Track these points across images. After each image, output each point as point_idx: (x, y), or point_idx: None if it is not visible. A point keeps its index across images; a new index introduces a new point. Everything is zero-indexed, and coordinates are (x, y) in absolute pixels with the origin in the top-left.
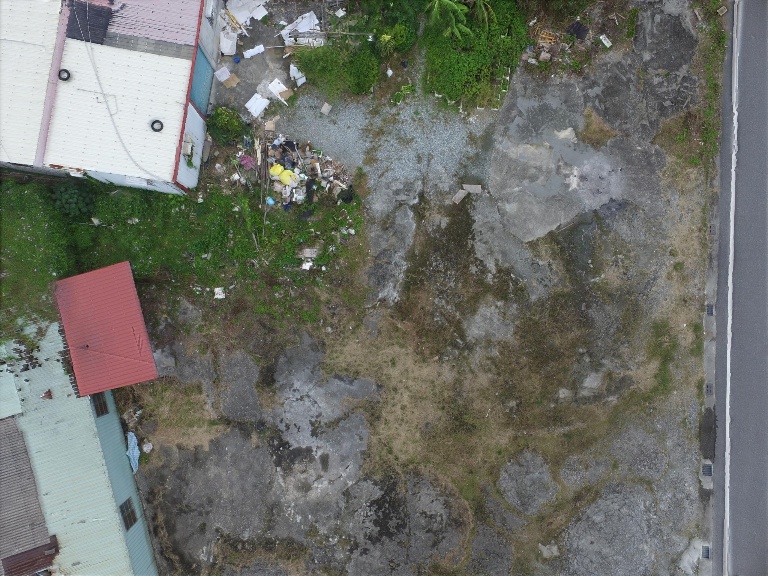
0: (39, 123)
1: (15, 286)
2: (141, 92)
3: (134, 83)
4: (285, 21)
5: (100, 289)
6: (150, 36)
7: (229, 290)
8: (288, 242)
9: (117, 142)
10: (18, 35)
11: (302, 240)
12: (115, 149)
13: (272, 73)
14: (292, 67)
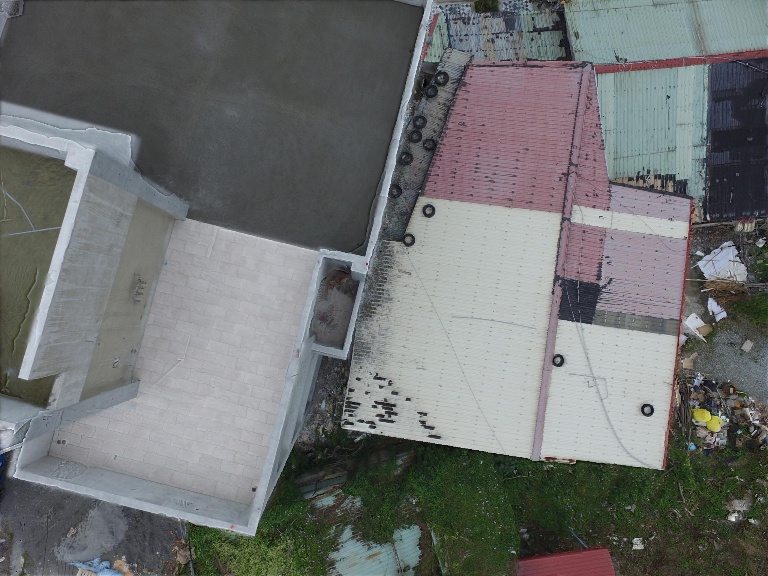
0: (534, 413)
1: (478, 568)
2: (630, 373)
3: (623, 364)
4: (702, 251)
5: (572, 575)
6: (637, 312)
7: (648, 541)
8: (716, 493)
9: (608, 429)
10: (506, 316)
11: (729, 490)
12: (606, 437)
13: (689, 307)
14: (711, 301)
